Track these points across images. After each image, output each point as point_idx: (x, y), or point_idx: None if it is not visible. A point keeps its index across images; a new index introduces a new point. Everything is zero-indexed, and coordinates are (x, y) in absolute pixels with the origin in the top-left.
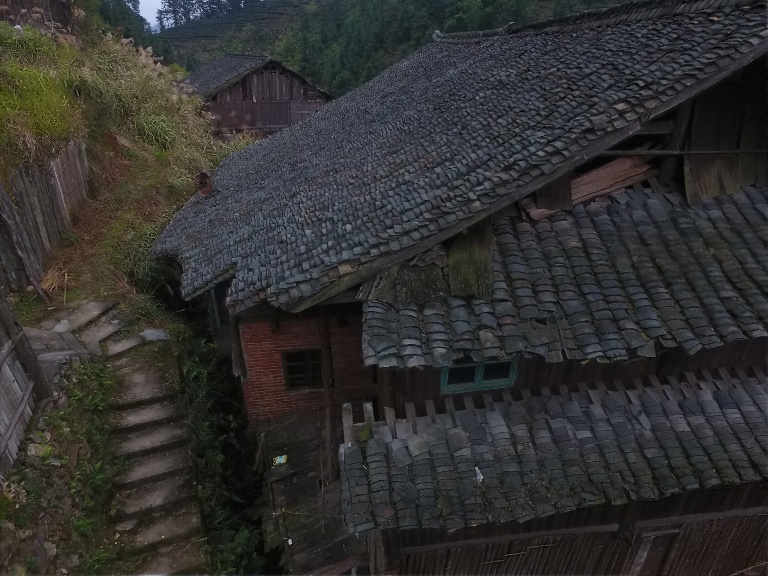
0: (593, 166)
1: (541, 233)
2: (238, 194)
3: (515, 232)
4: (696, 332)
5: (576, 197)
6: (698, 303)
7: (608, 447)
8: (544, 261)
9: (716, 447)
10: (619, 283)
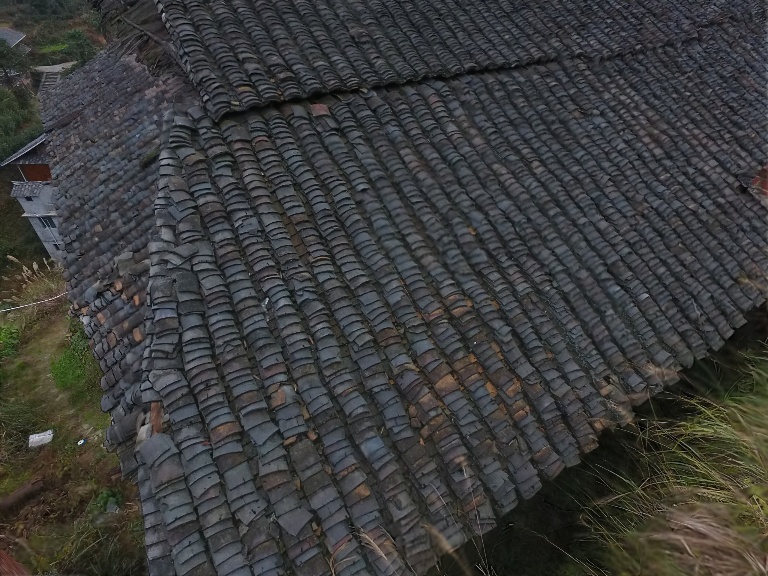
0: None
1: None
2: (761, 102)
3: None
4: None
5: None
6: None
7: None
8: None
9: None
10: None
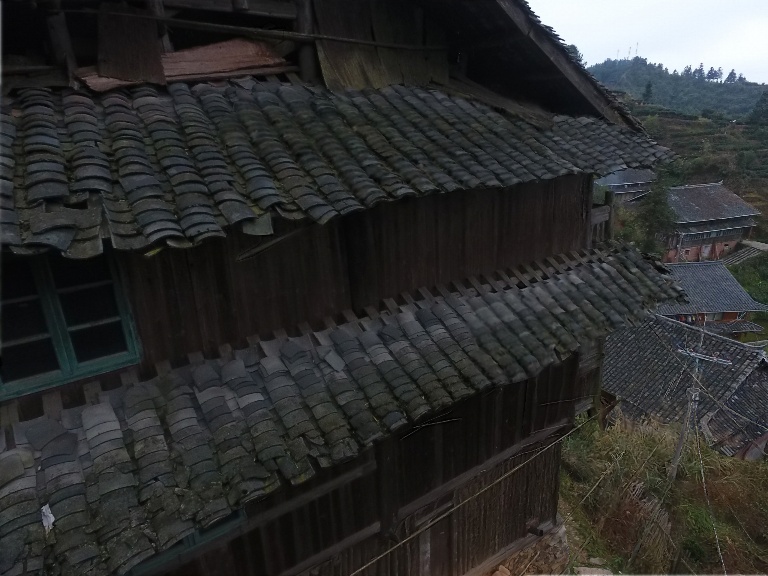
0: (198, 42)
1: (107, 107)
2: None
3: (60, 107)
4: (329, 199)
5: (173, 73)
6: (336, 174)
7: (286, 407)
8: (107, 139)
9: (422, 370)
10: (228, 159)
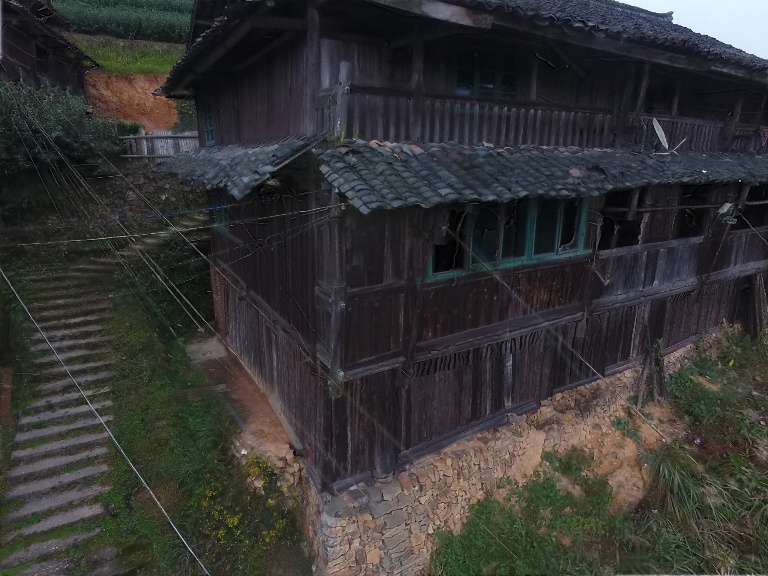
0: None
1: None
2: None
3: None
4: None
5: None
6: None
7: None
8: None
9: None
10: None
